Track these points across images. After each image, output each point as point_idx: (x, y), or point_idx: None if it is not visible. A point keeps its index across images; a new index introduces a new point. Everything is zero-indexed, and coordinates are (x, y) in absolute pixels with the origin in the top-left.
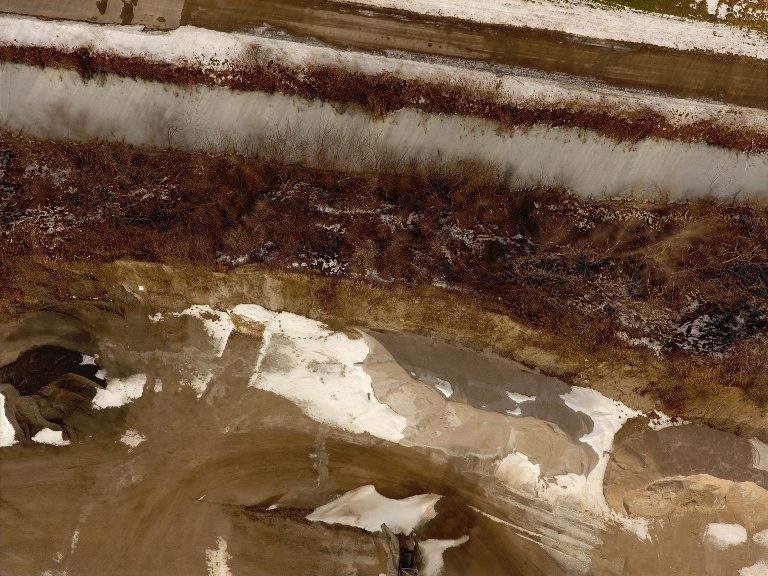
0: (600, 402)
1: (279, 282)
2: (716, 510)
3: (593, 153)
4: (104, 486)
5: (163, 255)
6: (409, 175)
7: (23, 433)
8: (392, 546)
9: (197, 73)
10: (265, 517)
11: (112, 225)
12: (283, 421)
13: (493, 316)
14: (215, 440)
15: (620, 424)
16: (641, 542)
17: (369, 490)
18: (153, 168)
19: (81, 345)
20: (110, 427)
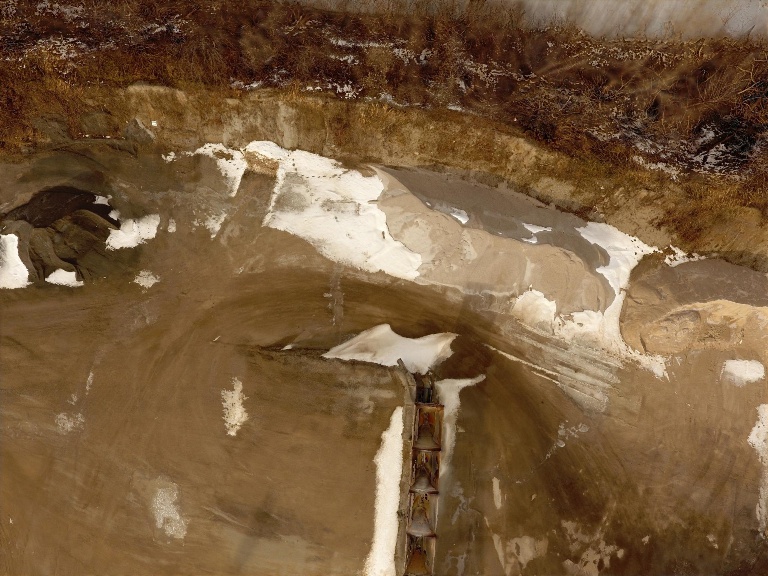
0: (616, 237)
1: (293, 111)
2: (733, 346)
3: None
4: (118, 327)
5: (177, 80)
6: (421, 17)
7: (37, 273)
8: (409, 378)
9: None
10: (280, 356)
11: (125, 52)
12: (298, 260)
13: (509, 140)
14: (229, 280)
15: (636, 260)
16: (658, 380)
17: (385, 329)
18: (165, 6)
19: (94, 186)
20: (124, 268)
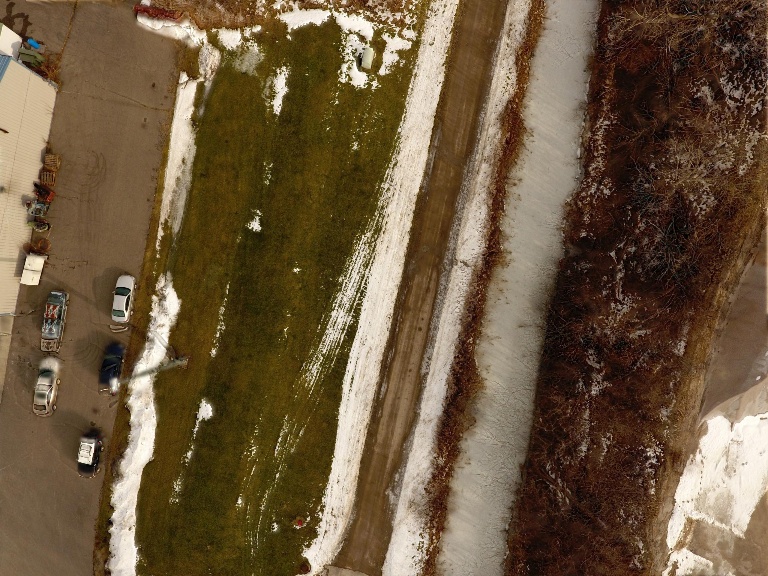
0: None
1: None
2: None
3: (533, 173)
4: None
5: None
6: (541, 358)
7: None
8: None
9: (428, 564)
10: None
11: None
12: None
13: None
14: None
15: None
16: None
17: None
18: None
19: None
20: None
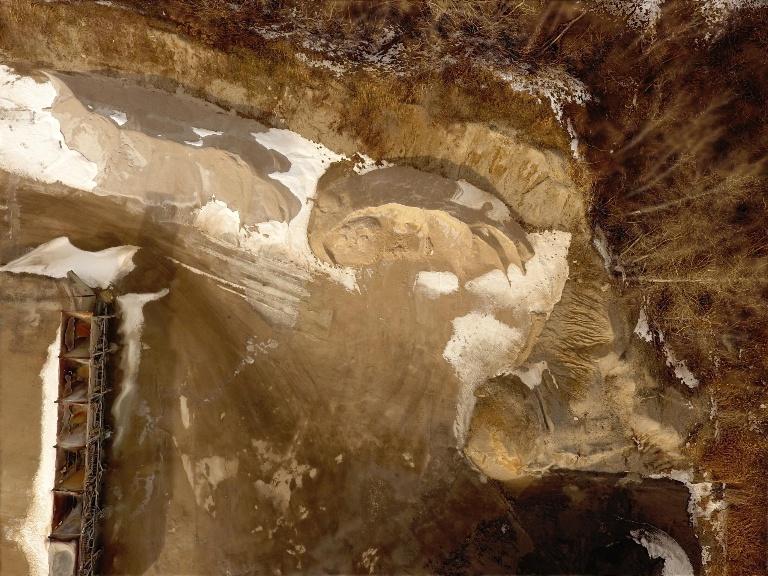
0: (299, 143)
1: None
2: (426, 257)
3: None
4: None
5: None
6: None
7: None
8: (74, 289)
9: None
10: None
11: None
12: None
13: (162, 36)
14: None
15: (323, 169)
16: (349, 293)
17: (62, 242)
18: None
19: None
20: None
